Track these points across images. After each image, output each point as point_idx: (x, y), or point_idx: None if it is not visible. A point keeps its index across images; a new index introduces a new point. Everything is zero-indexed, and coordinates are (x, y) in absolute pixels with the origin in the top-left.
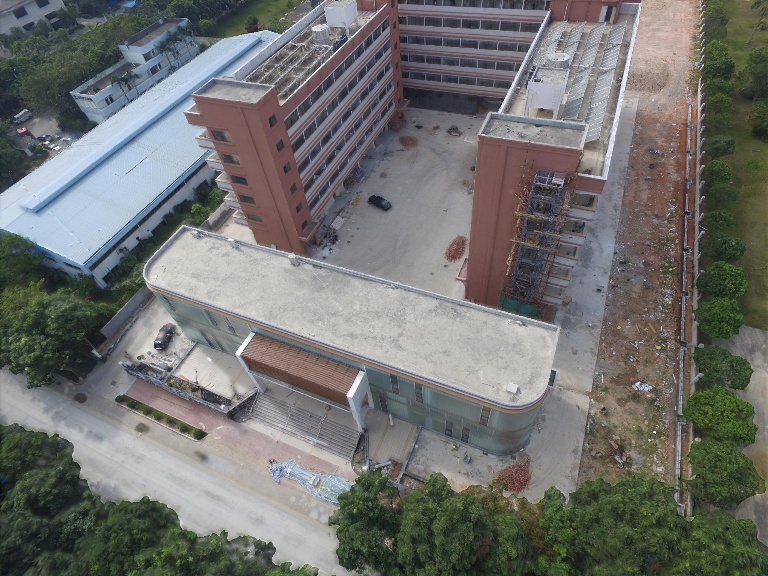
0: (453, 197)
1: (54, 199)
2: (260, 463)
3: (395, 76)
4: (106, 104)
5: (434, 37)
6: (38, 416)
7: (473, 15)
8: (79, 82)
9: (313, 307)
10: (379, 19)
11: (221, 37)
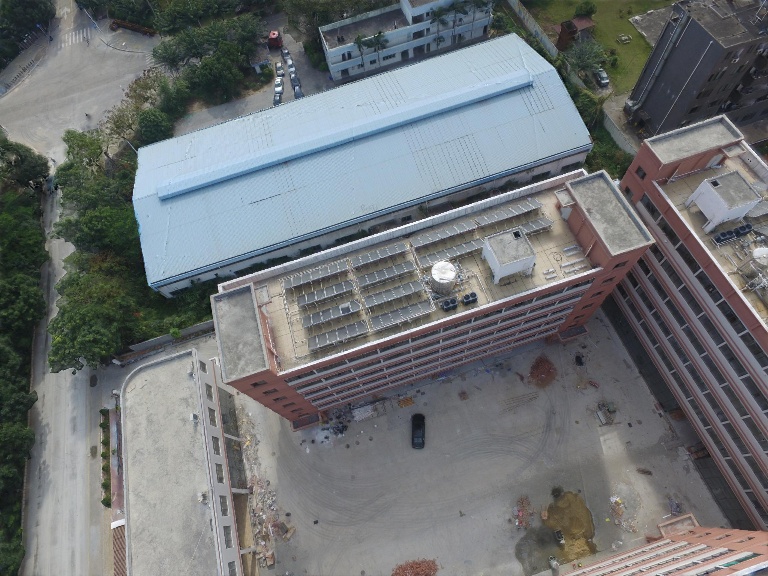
0: (489, 505)
1: (182, 194)
2: (109, 574)
3: (575, 313)
4: (341, 58)
5: (679, 311)
6: (68, 370)
7: (744, 359)
8: (336, 17)
9: (166, 567)
10: (566, 283)
11: (540, 6)
